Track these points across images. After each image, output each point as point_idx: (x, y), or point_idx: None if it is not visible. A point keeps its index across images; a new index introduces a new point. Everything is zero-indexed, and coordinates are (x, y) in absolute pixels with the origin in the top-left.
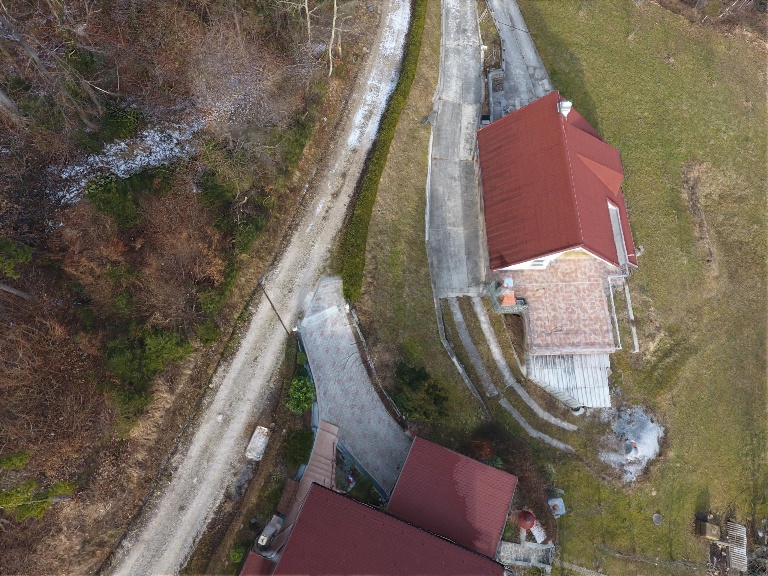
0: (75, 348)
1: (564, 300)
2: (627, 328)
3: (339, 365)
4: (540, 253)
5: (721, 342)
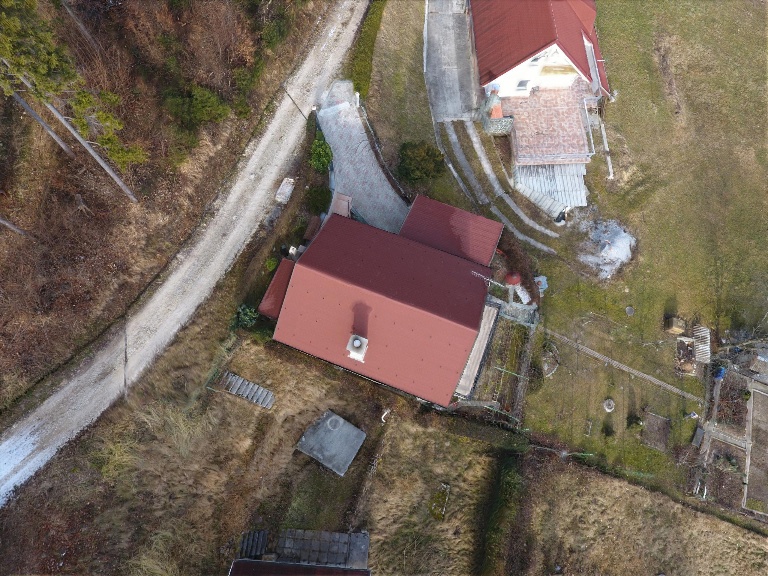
0: (135, 98)
1: (546, 121)
2: (603, 159)
3: (351, 149)
4: (522, 58)
5: (688, 180)
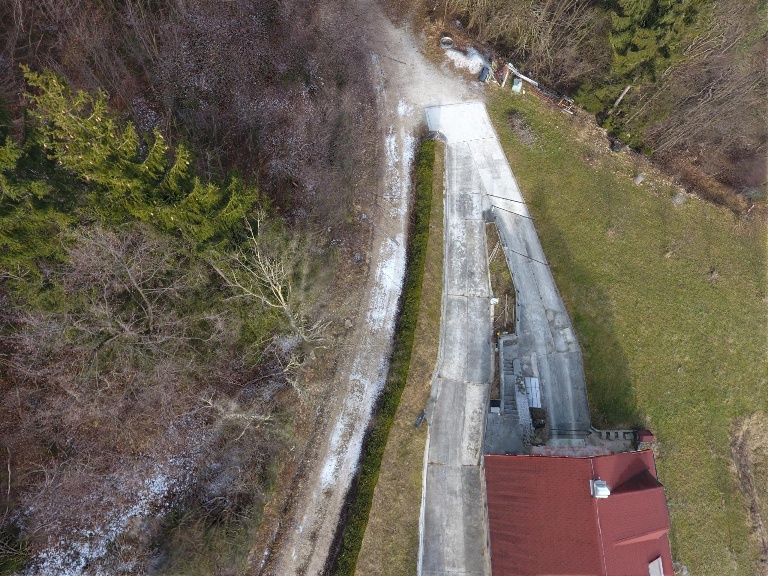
0: None
1: None
2: None
3: None
4: None
5: None
